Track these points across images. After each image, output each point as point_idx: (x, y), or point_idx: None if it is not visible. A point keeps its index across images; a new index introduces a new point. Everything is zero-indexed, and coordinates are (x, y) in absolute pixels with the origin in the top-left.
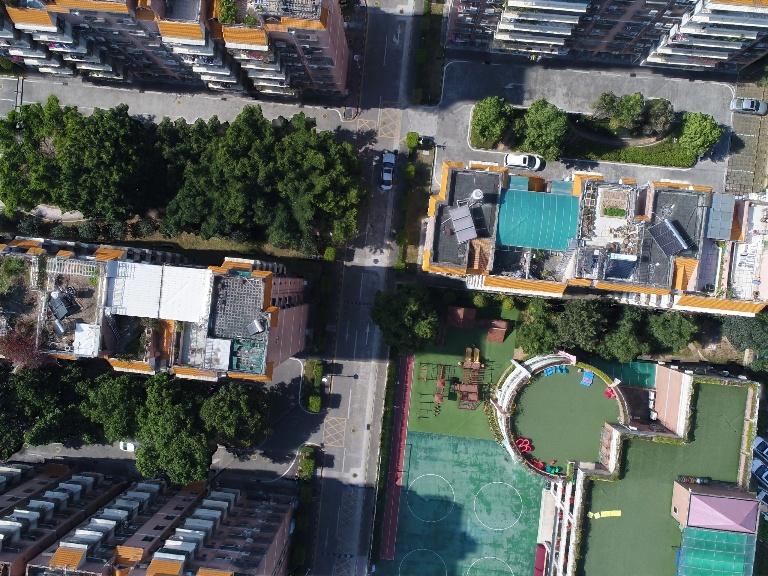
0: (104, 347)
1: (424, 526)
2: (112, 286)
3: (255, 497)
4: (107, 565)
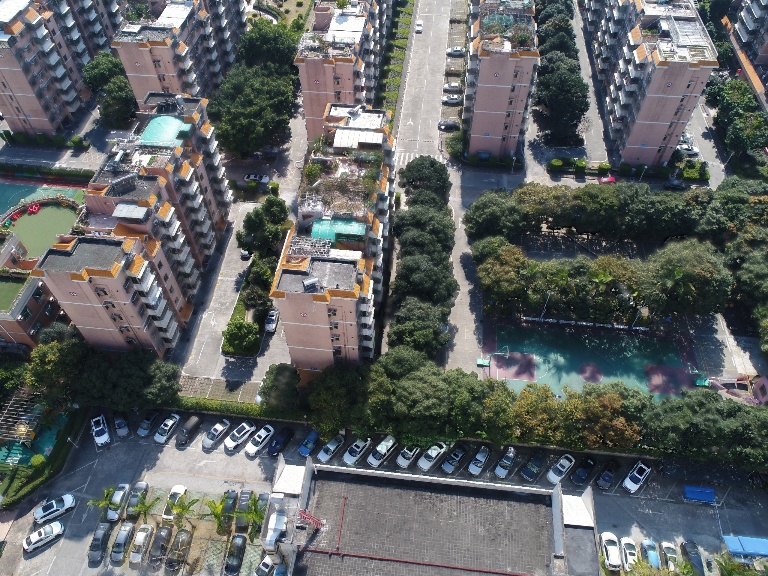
0: (153, 5)
1: (8, 197)
2: (181, 4)
3: (68, 122)
4: (44, 3)
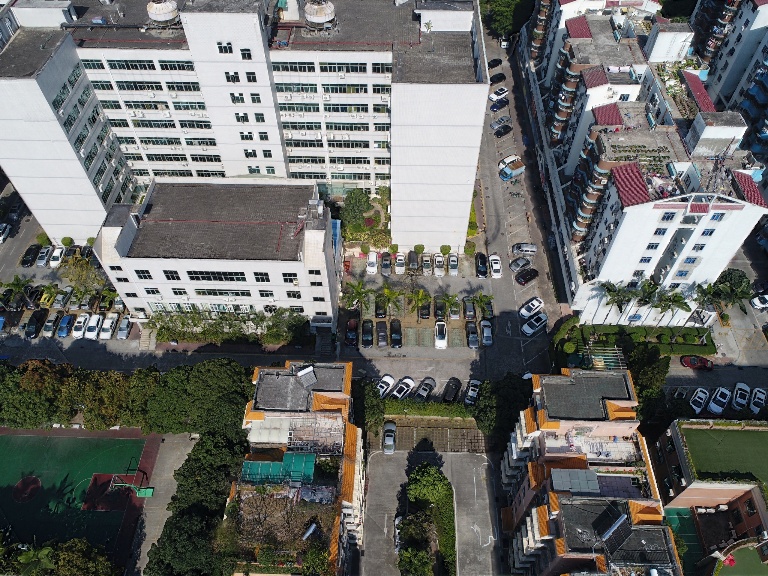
0: None
1: None
2: None
3: None
4: None
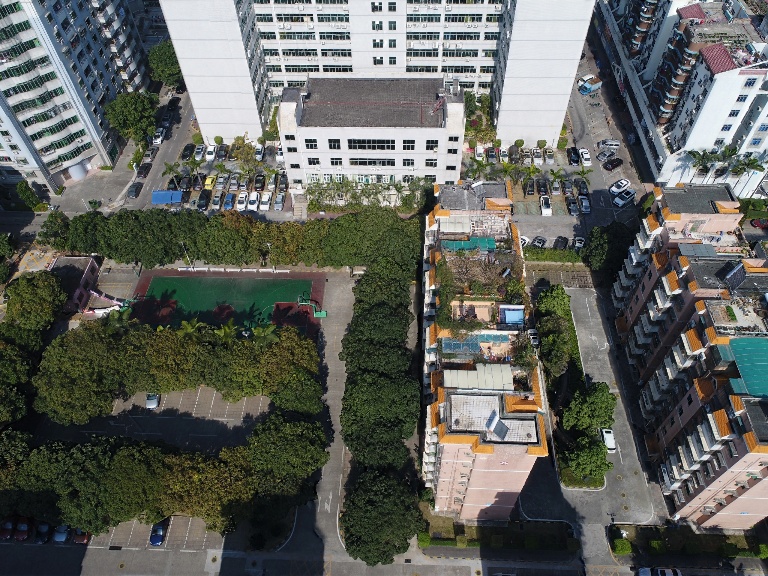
0: None
1: None
2: None
3: None
4: None
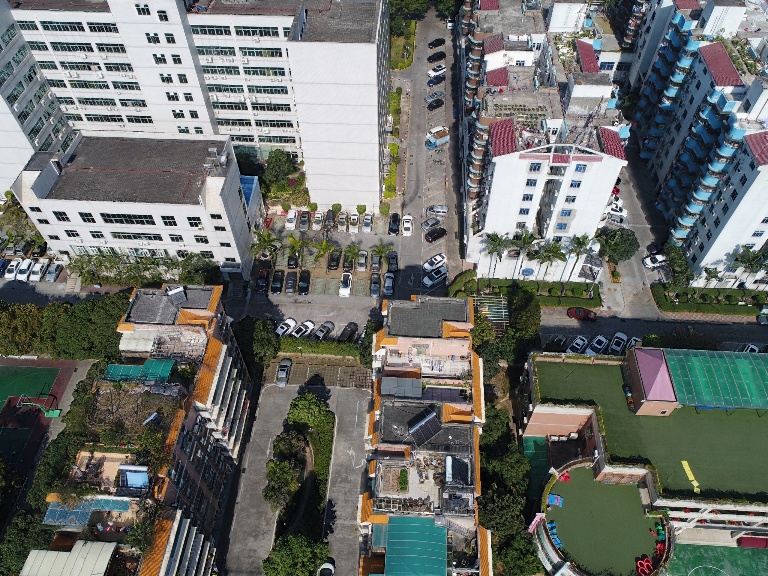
0: None
1: None
2: None
3: None
4: None
